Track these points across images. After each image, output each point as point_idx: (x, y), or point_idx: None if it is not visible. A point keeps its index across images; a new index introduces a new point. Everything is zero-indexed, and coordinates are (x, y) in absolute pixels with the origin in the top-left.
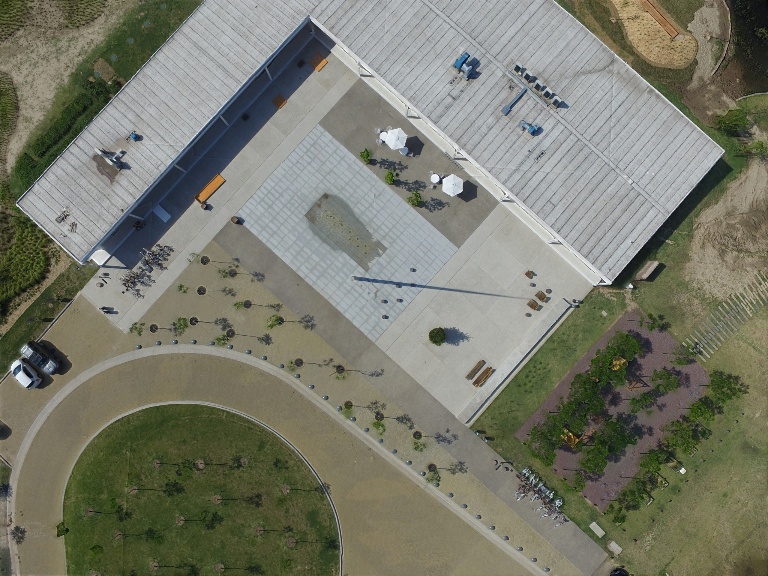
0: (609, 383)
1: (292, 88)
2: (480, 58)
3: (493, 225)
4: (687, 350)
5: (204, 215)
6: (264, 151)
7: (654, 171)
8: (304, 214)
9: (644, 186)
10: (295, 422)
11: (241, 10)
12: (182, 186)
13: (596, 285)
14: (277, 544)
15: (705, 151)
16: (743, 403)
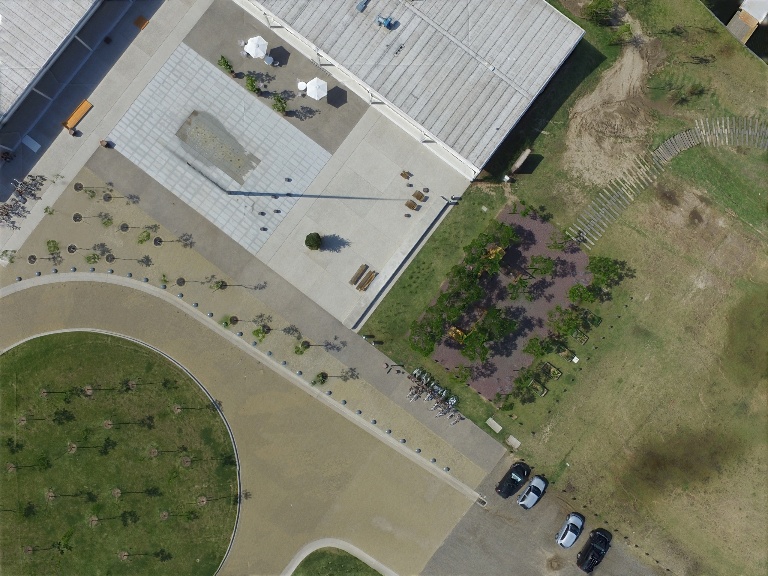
0: (494, 278)
1: (153, 8)
2: None
3: (365, 129)
4: (563, 233)
5: (74, 142)
6: (130, 73)
7: (515, 56)
8: (175, 133)
9: (506, 72)
10: (181, 342)
11: None
12: (50, 115)
13: (472, 180)
14: (172, 465)
15: (565, 32)
16: (631, 287)
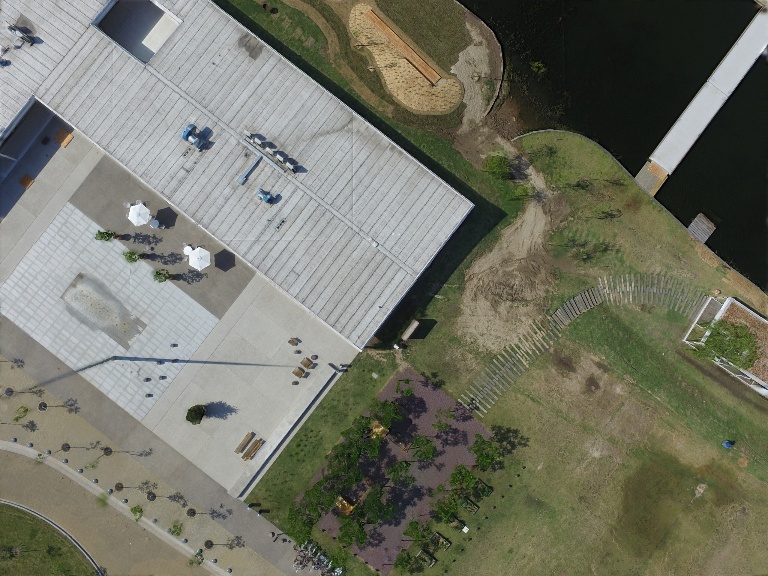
0: (384, 446)
1: (39, 166)
2: (213, 127)
3: (253, 293)
4: (447, 412)
5: None
6: (15, 234)
7: (400, 231)
8: (60, 296)
9: (390, 248)
10: (66, 508)
11: None
12: None
13: None
14: None
15: (452, 206)
16: (524, 456)
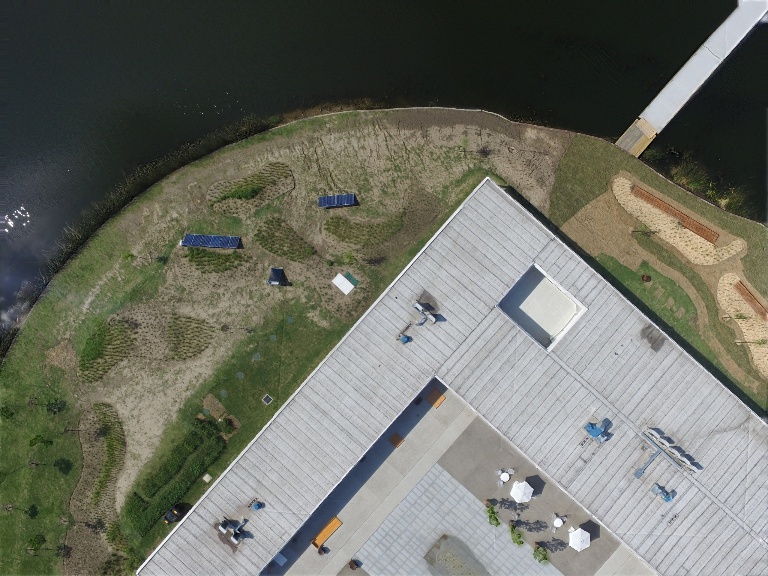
0: None
1: (409, 426)
2: (612, 418)
3: (616, 565)
4: None
5: (321, 558)
6: (381, 492)
7: None
8: (423, 556)
9: None
10: None
11: (364, 369)
12: None
13: None
14: None
15: None
16: None
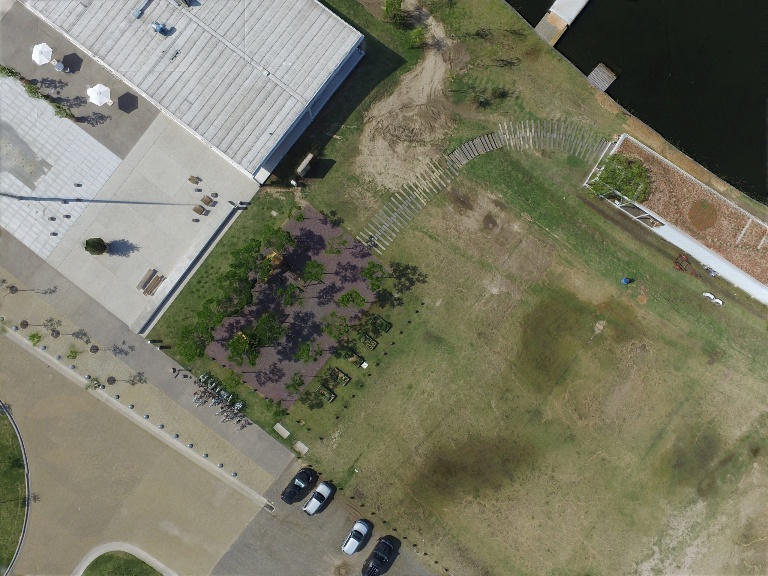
0: (283, 283)
1: None
2: None
3: (156, 134)
4: (339, 238)
5: None
6: None
7: (291, 61)
8: None
9: (281, 77)
10: None
11: None
12: None
13: (260, 185)
14: None
15: (342, 37)
16: (422, 293)
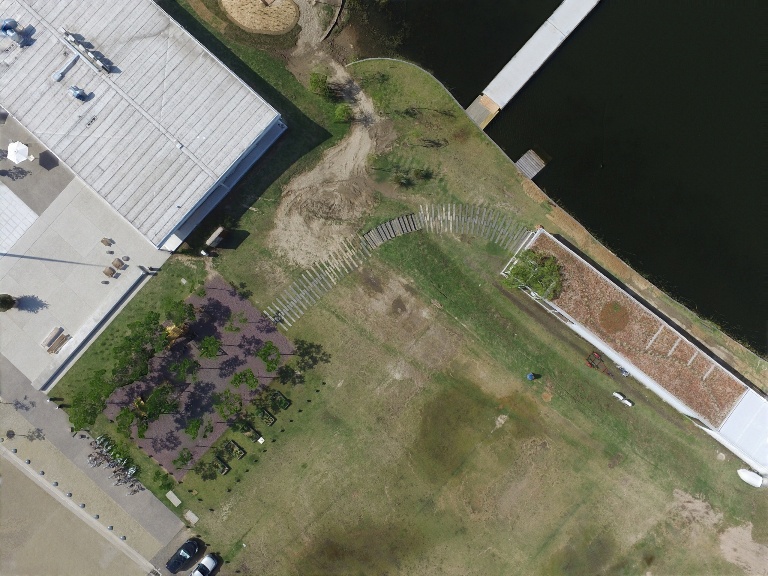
0: (187, 351)
1: None
2: (35, 25)
3: (73, 193)
4: (240, 316)
5: None
6: None
7: (205, 135)
8: None
9: (194, 150)
10: None
11: None
12: None
13: (171, 252)
14: None
15: (258, 114)
16: (325, 372)
